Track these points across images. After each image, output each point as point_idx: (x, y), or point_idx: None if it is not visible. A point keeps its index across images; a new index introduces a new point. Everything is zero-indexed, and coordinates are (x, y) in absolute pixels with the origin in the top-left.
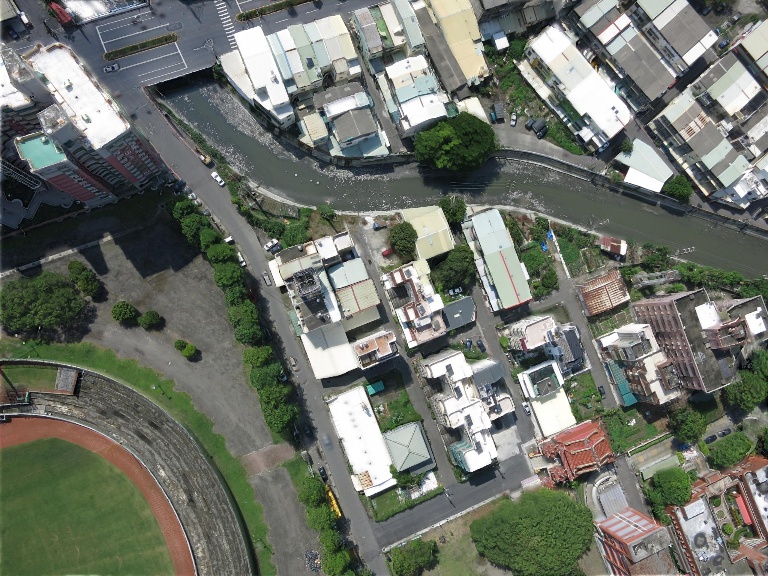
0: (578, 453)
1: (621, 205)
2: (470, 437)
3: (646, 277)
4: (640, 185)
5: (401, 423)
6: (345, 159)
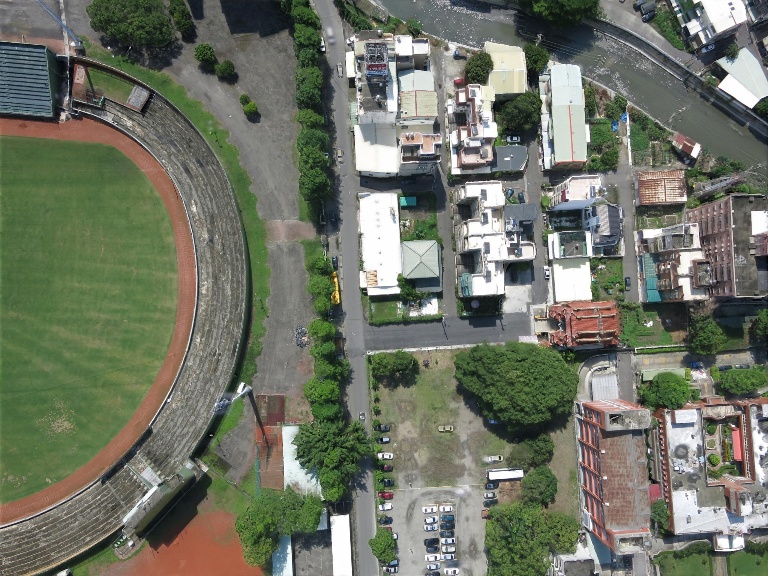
0: (584, 319)
1: (707, 114)
2: (483, 261)
3: (710, 182)
4: (734, 95)
5: (422, 239)
6: None
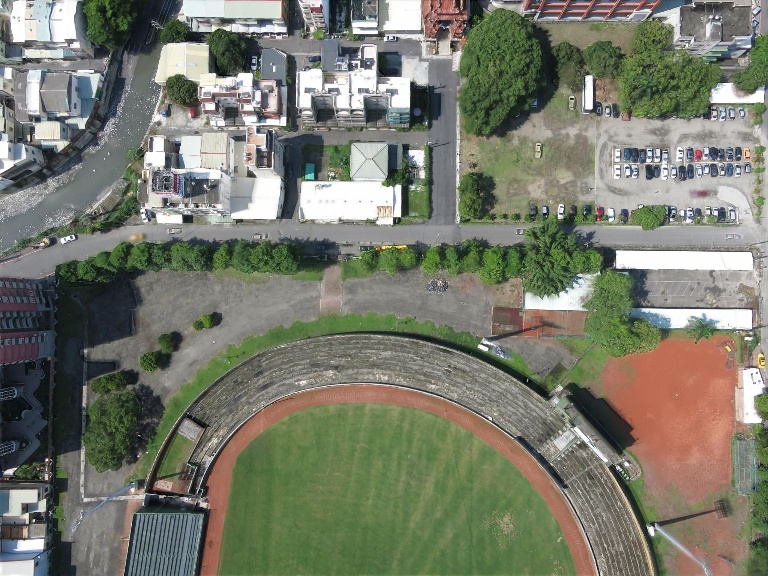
0: None
1: None
2: (377, 95)
3: None
4: None
5: (349, 160)
6: (94, 119)
